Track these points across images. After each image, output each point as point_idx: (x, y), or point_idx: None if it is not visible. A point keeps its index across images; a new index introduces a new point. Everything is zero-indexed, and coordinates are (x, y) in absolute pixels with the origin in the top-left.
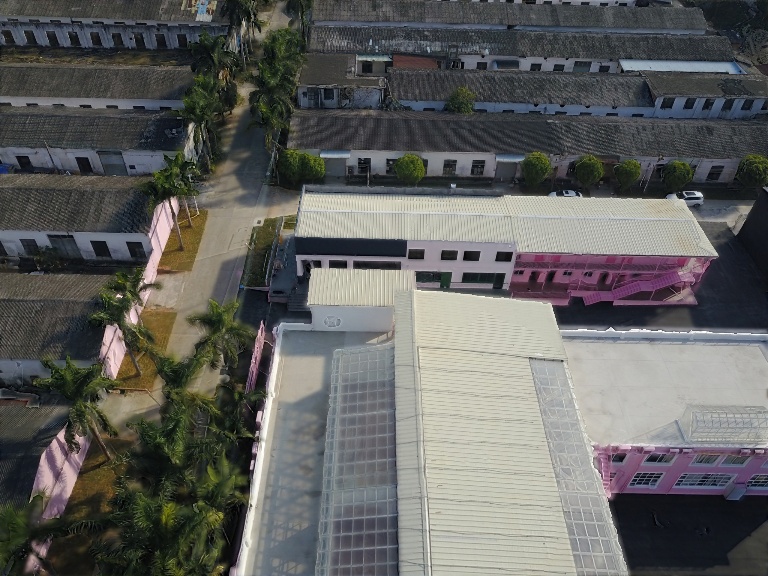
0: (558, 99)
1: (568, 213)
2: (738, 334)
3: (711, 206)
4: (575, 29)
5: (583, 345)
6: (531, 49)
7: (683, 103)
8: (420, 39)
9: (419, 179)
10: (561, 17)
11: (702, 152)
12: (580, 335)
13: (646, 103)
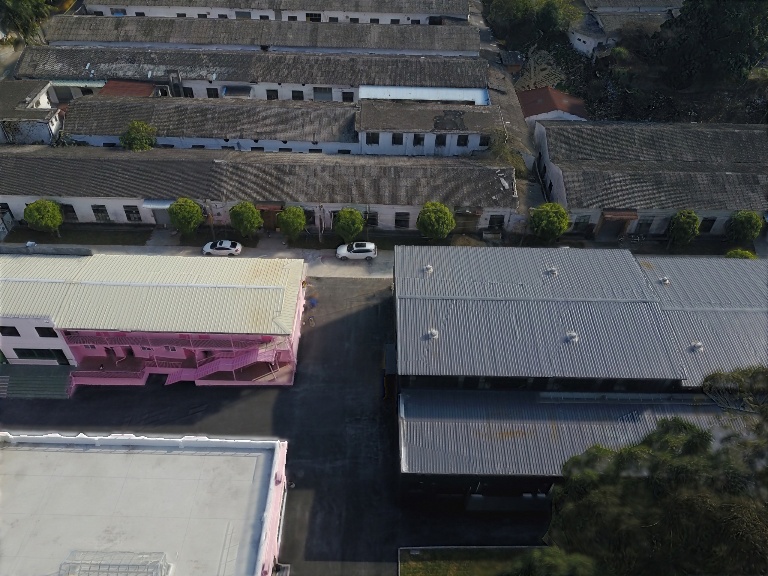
0: (251, 133)
1: (144, 278)
2: (236, 441)
3: (388, 259)
4: (335, 50)
5: (42, 455)
6: (264, 74)
7: (390, 138)
8: (144, 62)
9: (54, 227)
10: (320, 37)
11: (380, 197)
12: (47, 441)
13: (350, 138)
